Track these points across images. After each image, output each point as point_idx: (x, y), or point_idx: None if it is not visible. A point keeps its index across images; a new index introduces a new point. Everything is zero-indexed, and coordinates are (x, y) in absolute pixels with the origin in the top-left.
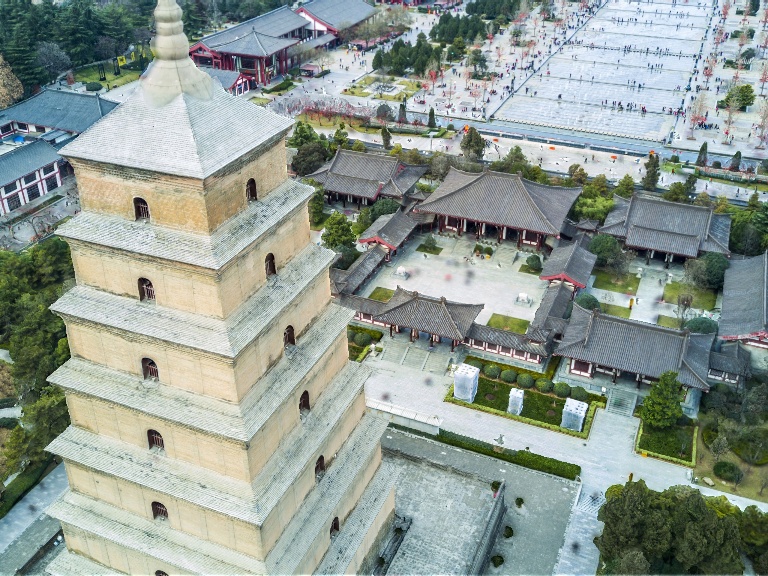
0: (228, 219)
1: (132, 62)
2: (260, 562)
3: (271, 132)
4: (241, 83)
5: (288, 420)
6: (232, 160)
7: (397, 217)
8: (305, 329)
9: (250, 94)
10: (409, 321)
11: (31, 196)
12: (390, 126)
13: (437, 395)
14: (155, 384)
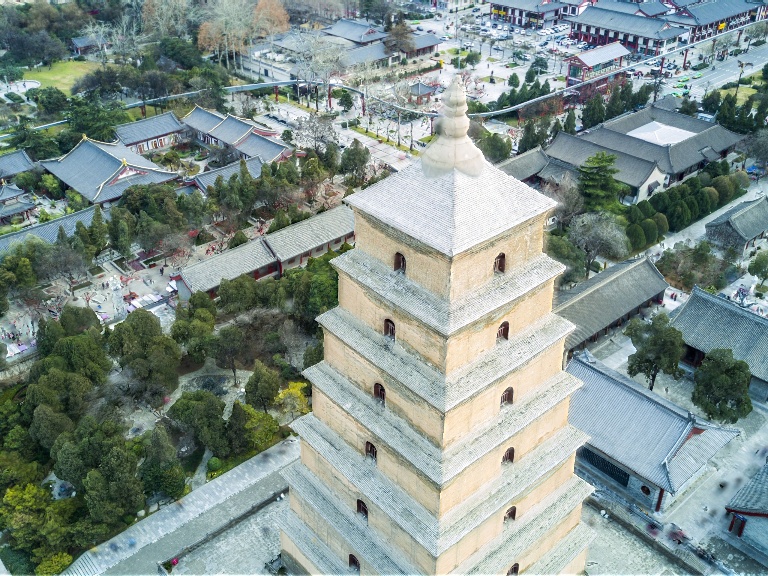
0: None
1: None
2: None
3: None
4: None
5: None
6: None
7: None
8: None
9: None
10: None
11: None
12: None
13: None
14: None
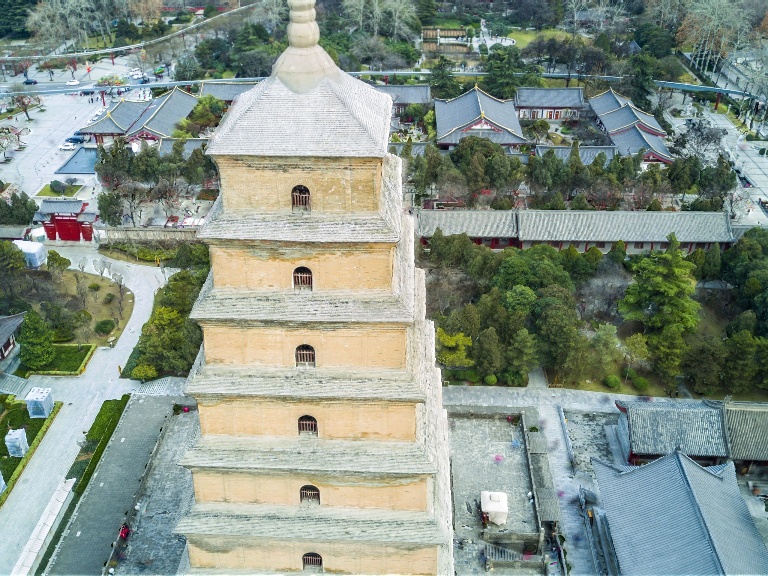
0: None
1: None
2: None
3: None
4: None
5: None
6: None
7: None
8: None
9: None
10: None
11: None
12: None
13: None
14: None
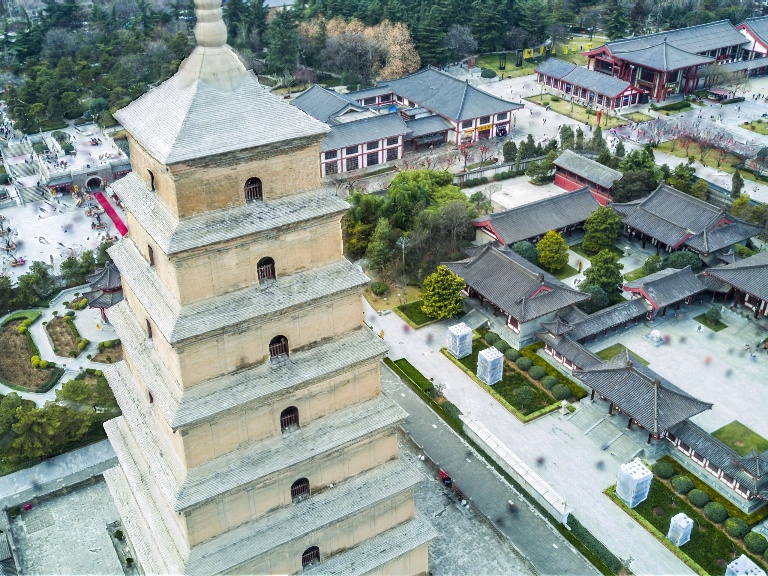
0: (211, 211)
1: (539, 56)
2: (188, 548)
3: (286, 135)
4: (629, 95)
5: (258, 427)
6: (212, 153)
7: (681, 274)
8: (310, 345)
9: (636, 108)
10: (609, 390)
11: (370, 162)
12: (765, 173)
13: (600, 482)
14: (152, 345)
